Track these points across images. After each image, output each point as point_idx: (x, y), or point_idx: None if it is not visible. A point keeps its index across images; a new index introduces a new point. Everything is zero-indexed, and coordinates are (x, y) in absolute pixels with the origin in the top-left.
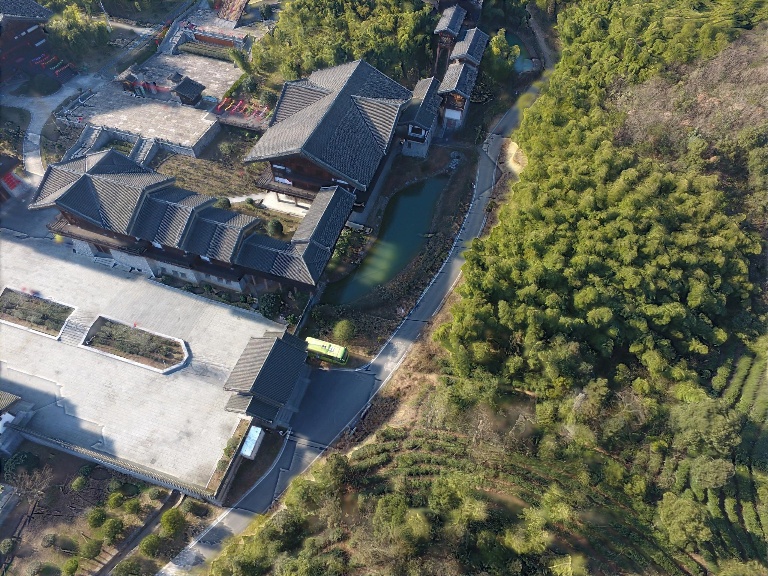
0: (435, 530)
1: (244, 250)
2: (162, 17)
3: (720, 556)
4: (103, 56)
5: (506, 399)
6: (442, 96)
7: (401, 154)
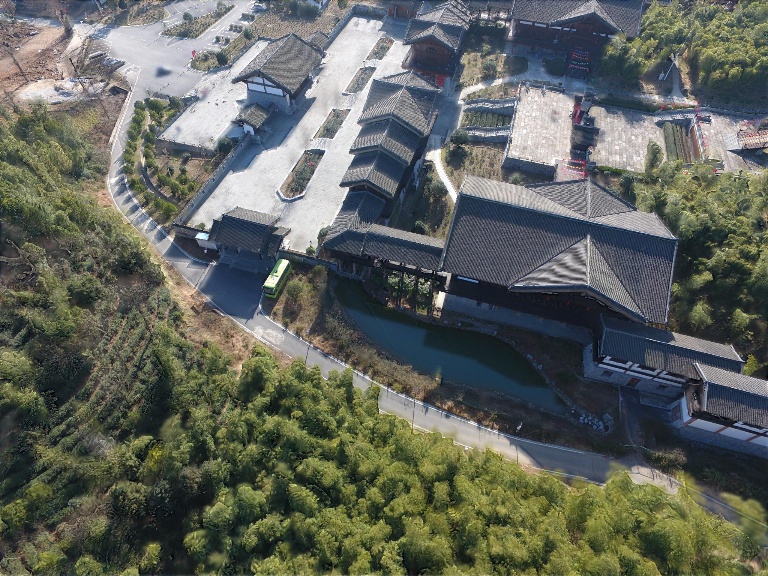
0: None
1: (359, 194)
2: (714, 102)
3: None
4: (619, 85)
5: None
6: None
7: (582, 347)
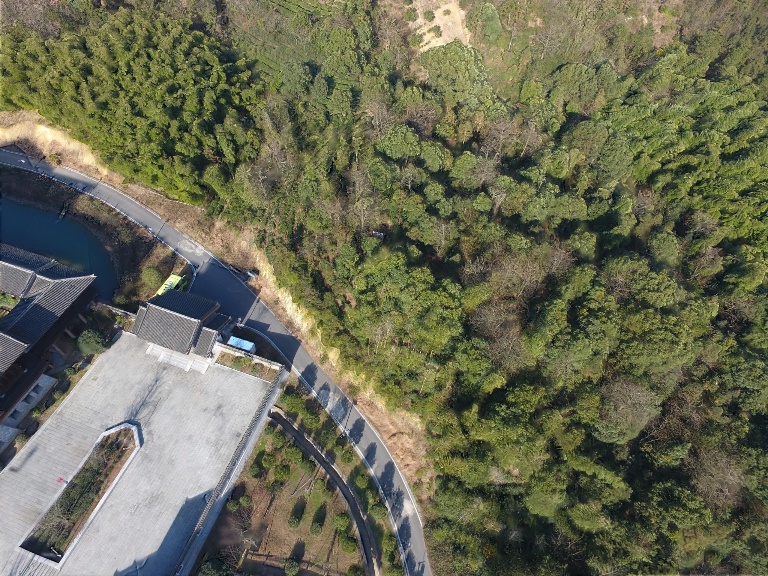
0: None
1: None
2: None
3: (358, 104)
4: None
5: None
6: None
7: None
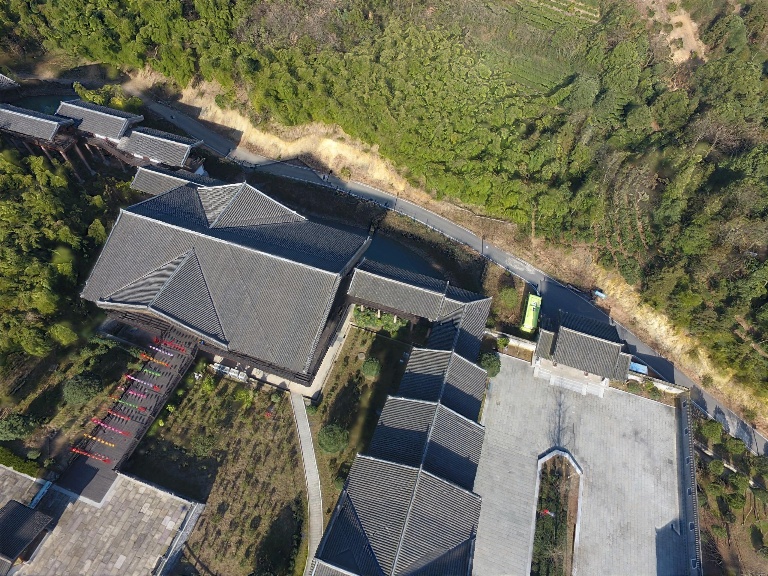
0: (685, 224)
1: None
2: None
3: None
4: None
5: None
6: (176, 169)
7: None
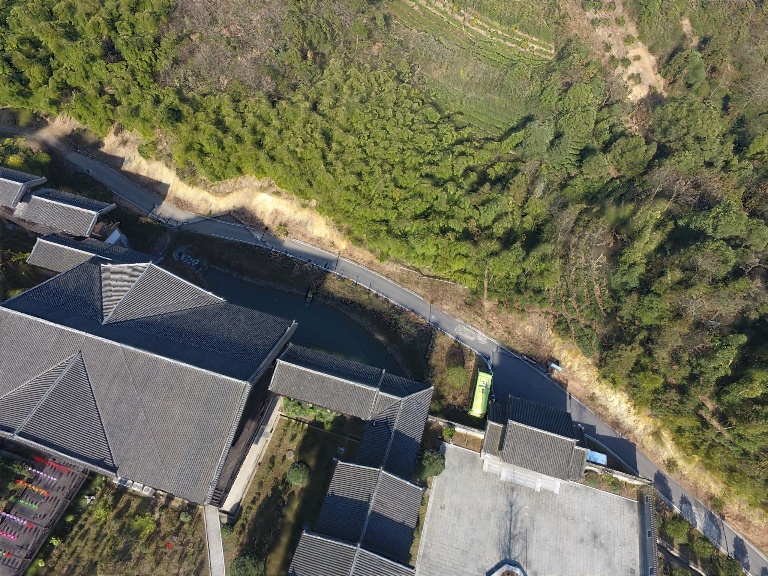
0: (644, 289)
1: None
2: None
3: None
4: None
5: (504, 253)
6: (83, 238)
7: None
